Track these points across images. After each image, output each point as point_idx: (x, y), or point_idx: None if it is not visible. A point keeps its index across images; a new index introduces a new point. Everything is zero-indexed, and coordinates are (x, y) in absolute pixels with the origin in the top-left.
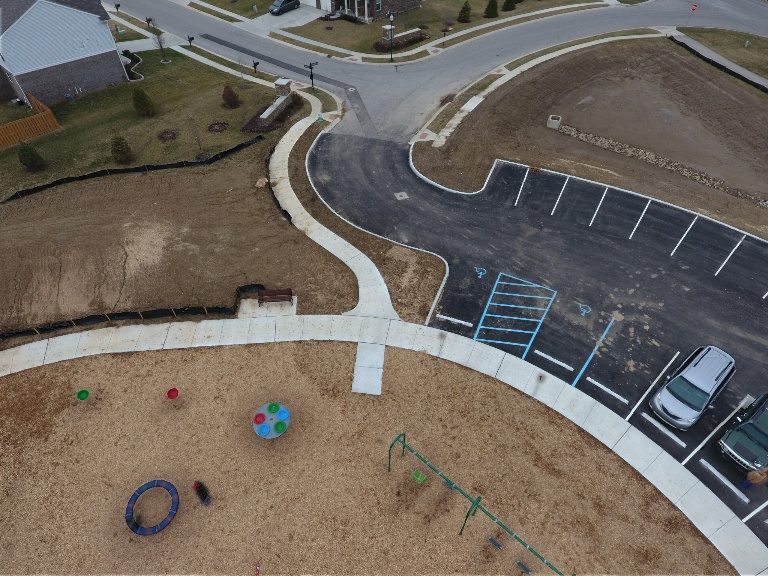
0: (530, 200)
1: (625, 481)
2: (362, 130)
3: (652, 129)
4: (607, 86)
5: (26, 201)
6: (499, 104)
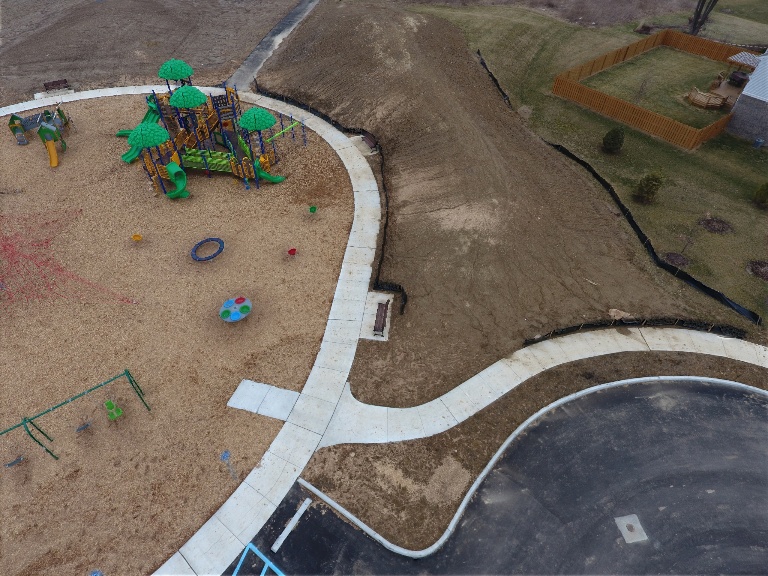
0: None
1: None
2: None
3: None
4: None
5: (551, 153)
6: None
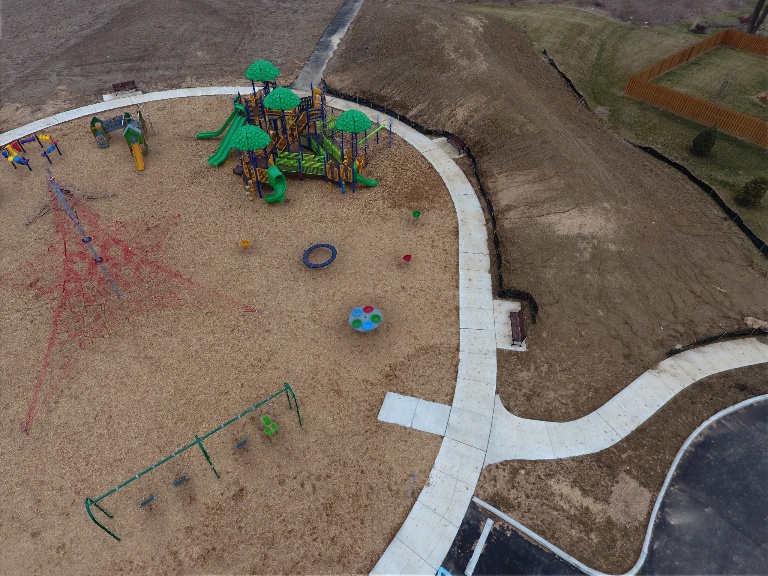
0: None
1: None
2: None
3: None
4: None
5: (641, 155)
6: None
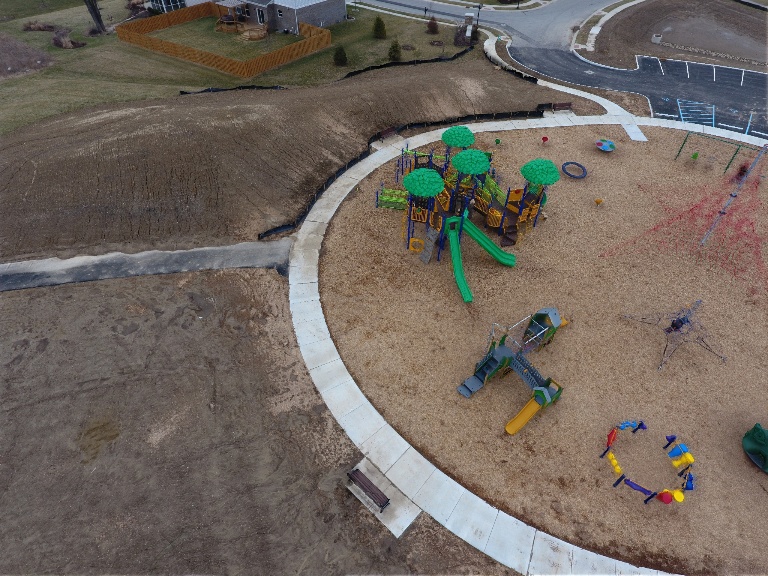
0: (671, 72)
1: None
2: (533, 44)
3: (721, 43)
4: (678, 21)
5: (358, 77)
6: (616, 29)
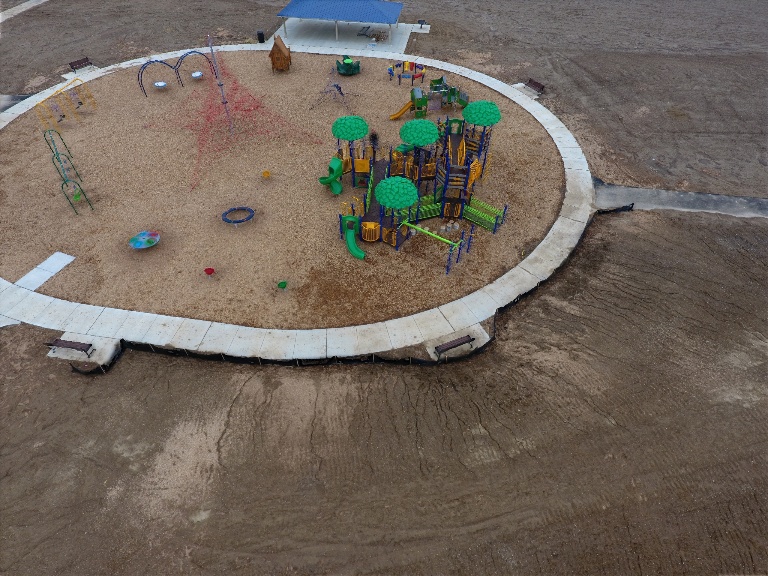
0: None
1: None
2: None
3: None
4: None
5: None
6: None
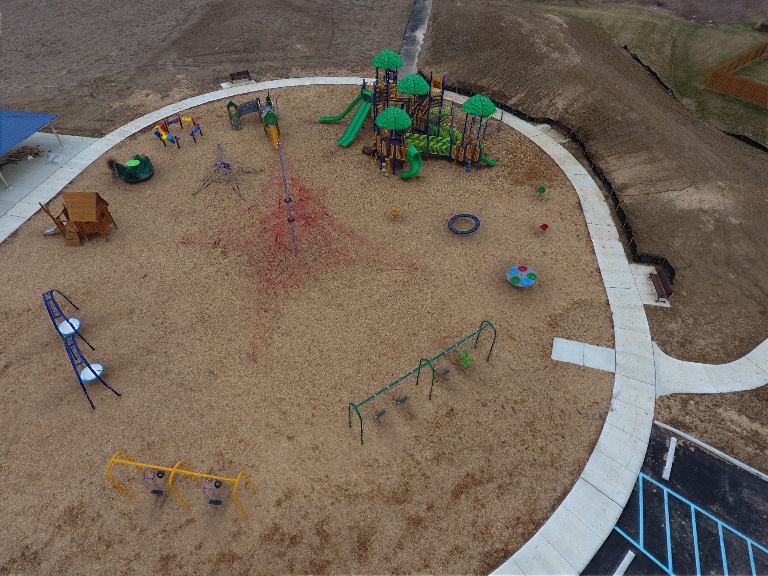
0: None
1: (439, 574)
2: None
3: None
4: None
5: (736, 142)
6: None
